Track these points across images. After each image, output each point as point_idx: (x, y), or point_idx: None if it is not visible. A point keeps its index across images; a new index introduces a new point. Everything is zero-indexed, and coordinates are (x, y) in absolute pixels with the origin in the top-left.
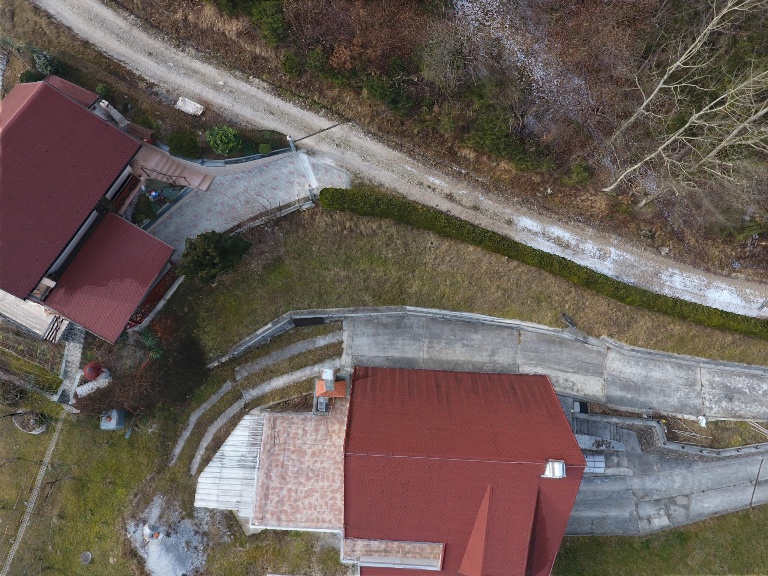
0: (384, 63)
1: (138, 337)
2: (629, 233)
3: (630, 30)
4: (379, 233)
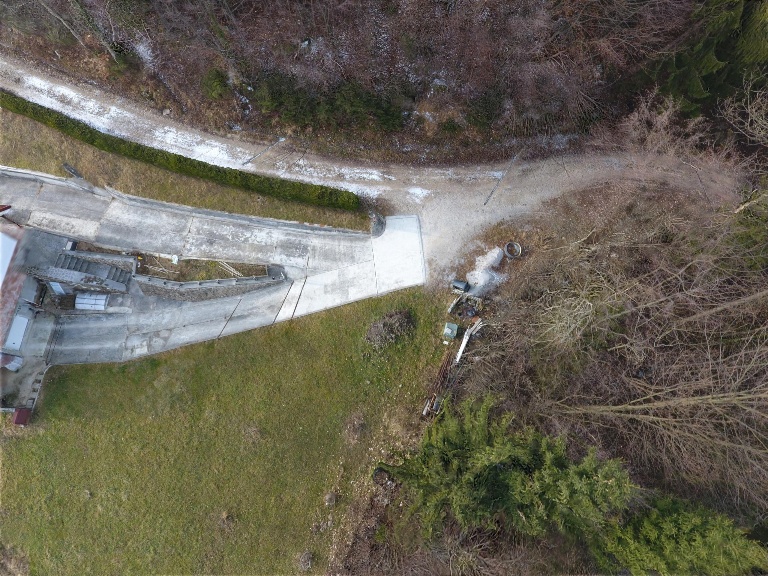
0: None
1: None
2: (137, 96)
3: None
4: None
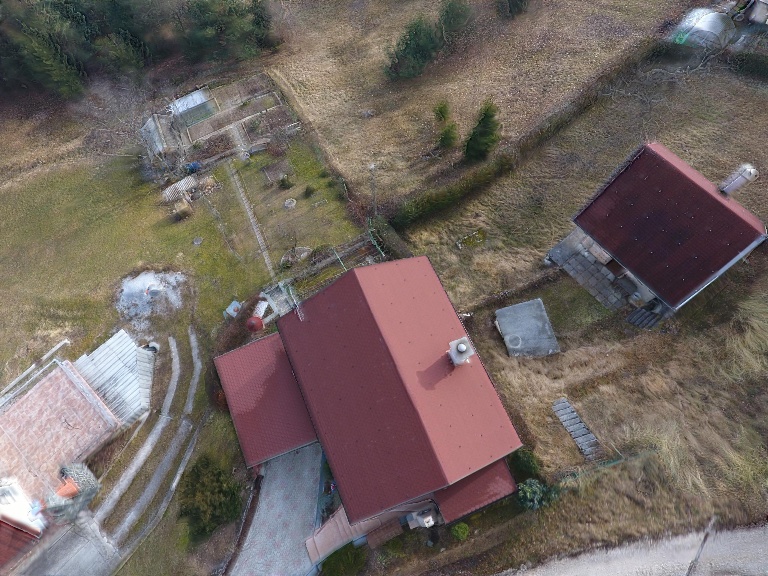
0: None
1: None
2: None
3: None
4: None
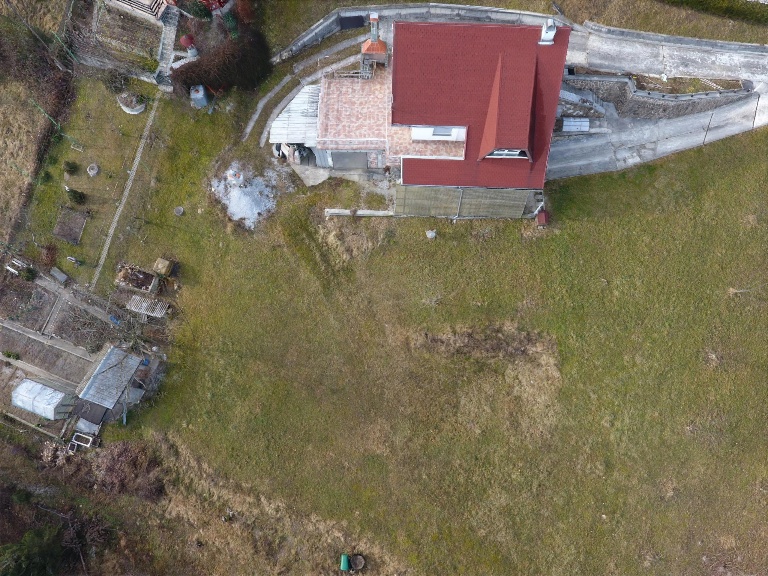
0: None
1: (220, 21)
2: None
3: None
4: None
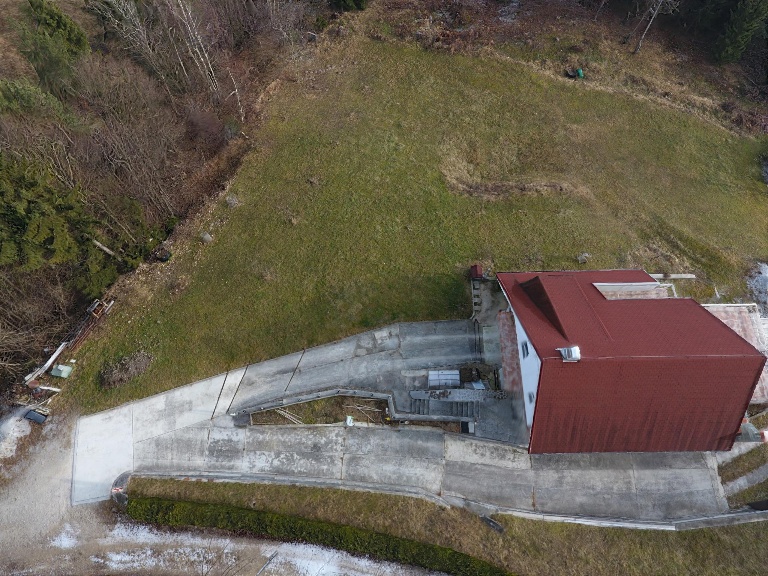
0: None
1: None
2: None
3: None
4: None
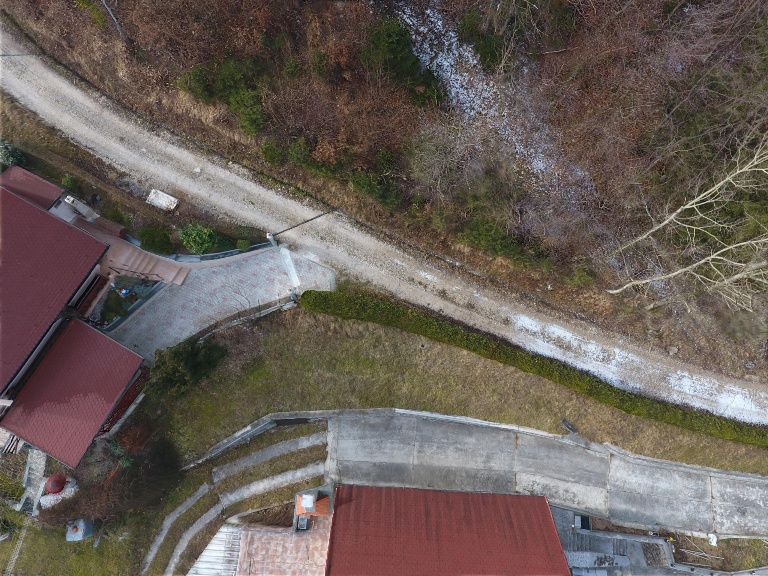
0: (371, 158)
1: (106, 444)
2: (635, 331)
3: (637, 119)
4: (366, 335)
